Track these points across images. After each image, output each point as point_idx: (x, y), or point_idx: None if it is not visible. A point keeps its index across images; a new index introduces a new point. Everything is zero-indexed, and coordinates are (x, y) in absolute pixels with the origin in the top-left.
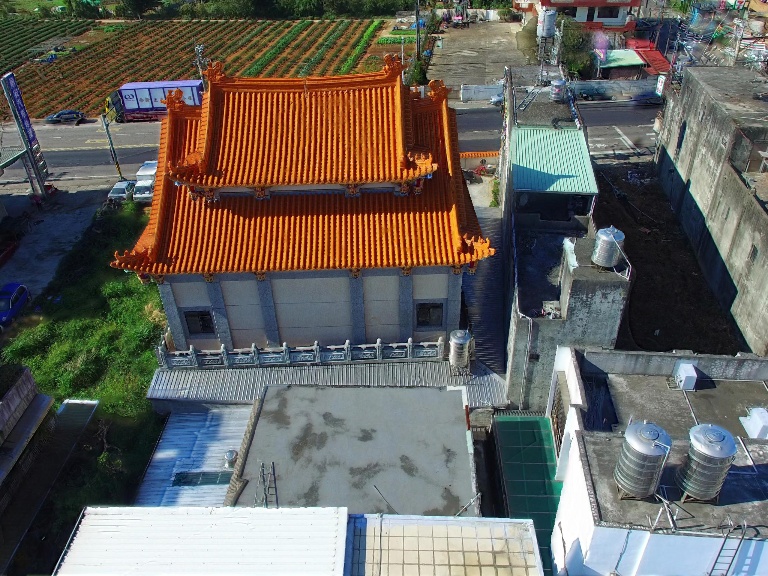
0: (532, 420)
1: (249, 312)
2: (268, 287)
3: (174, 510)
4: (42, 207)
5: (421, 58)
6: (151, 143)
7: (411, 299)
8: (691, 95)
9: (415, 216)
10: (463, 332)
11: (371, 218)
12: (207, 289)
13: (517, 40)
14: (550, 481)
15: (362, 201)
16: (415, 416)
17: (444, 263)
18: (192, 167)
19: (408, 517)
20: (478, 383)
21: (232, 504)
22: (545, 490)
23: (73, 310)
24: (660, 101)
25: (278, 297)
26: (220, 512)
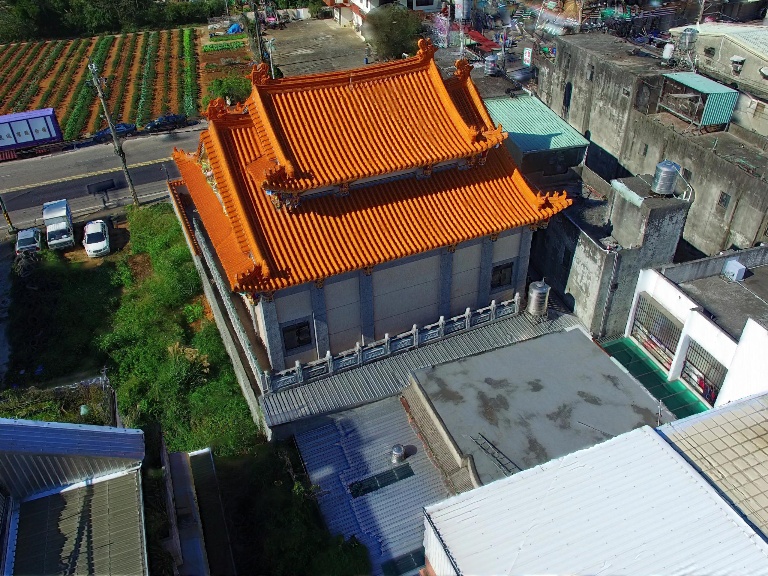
0: (617, 343)
1: (347, 312)
2: (369, 281)
3: (508, 480)
4: None
5: (265, 60)
6: (18, 186)
7: (491, 264)
8: (572, 59)
9: (485, 185)
10: (542, 282)
11: (449, 194)
12: (310, 297)
13: (364, 32)
14: (667, 383)
15: (434, 181)
16: (560, 359)
17: (532, 221)
18: (278, 173)
19: (689, 418)
20: (558, 325)
21: (477, 478)
22: (668, 391)
23: (70, 376)
24: (530, 70)
25: (375, 290)
26: (551, 466)
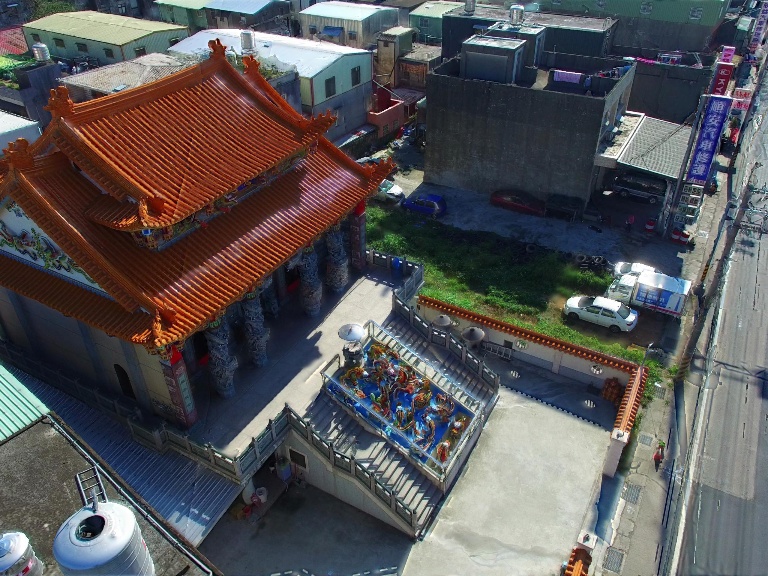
0: None
1: None
2: None
3: None
4: (632, 231)
5: None
6: None
7: None
8: None
9: None
10: None
11: None
12: None
13: None
14: None
15: None
16: None
17: None
18: None
19: None
20: None
21: None
22: None
23: None
24: None
25: None
26: None
